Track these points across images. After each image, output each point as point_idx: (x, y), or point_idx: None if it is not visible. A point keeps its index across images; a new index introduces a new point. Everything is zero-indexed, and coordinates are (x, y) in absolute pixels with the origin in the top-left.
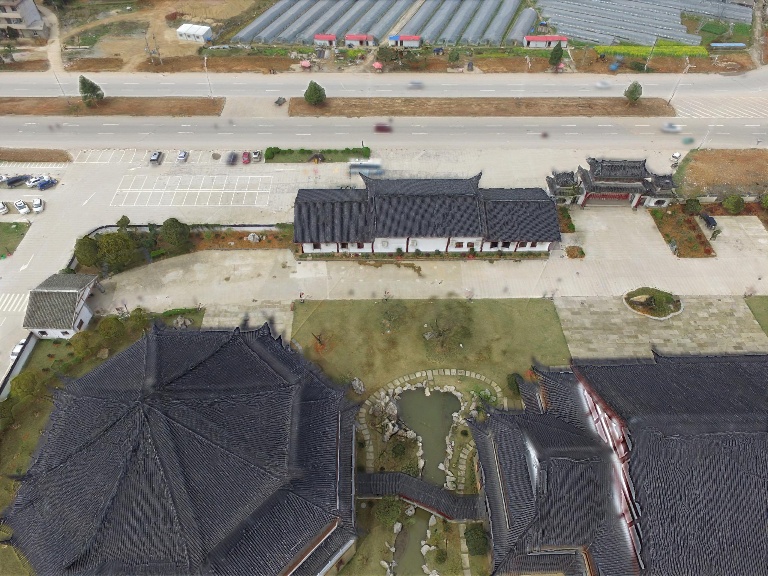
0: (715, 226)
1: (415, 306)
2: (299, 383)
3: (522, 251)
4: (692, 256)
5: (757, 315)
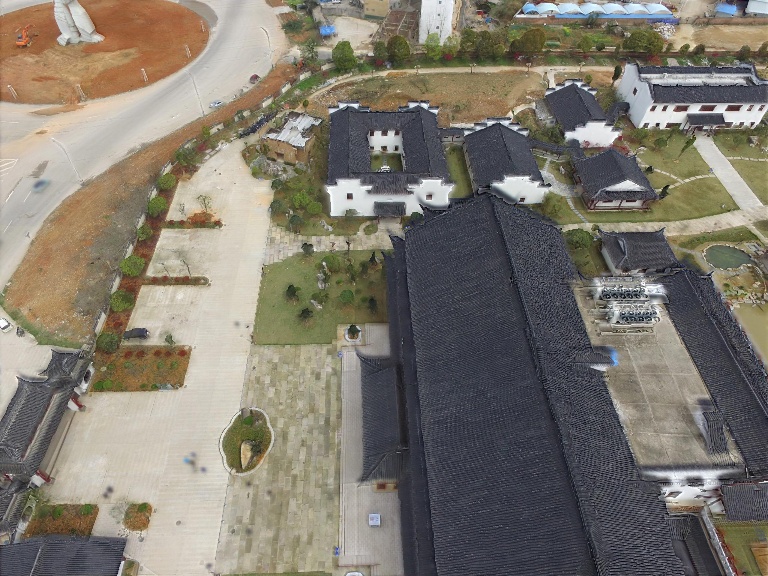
0: (147, 331)
1: None
2: None
3: None
4: (184, 371)
5: (279, 342)
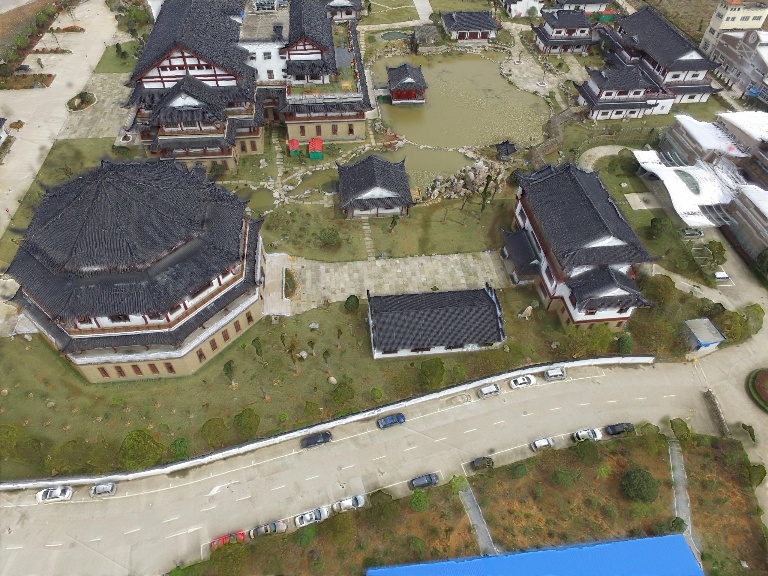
0: (29, 67)
1: (29, 203)
2: (102, 161)
3: (0, 147)
4: (50, 82)
5: (109, 72)
